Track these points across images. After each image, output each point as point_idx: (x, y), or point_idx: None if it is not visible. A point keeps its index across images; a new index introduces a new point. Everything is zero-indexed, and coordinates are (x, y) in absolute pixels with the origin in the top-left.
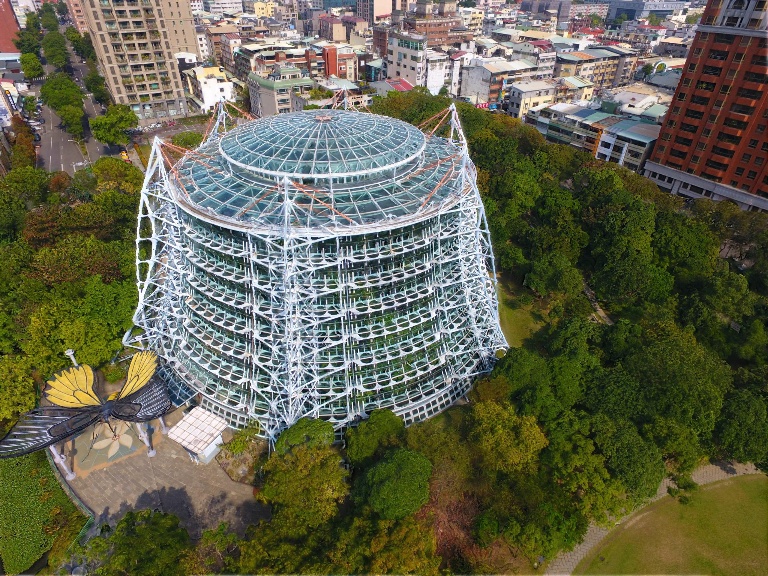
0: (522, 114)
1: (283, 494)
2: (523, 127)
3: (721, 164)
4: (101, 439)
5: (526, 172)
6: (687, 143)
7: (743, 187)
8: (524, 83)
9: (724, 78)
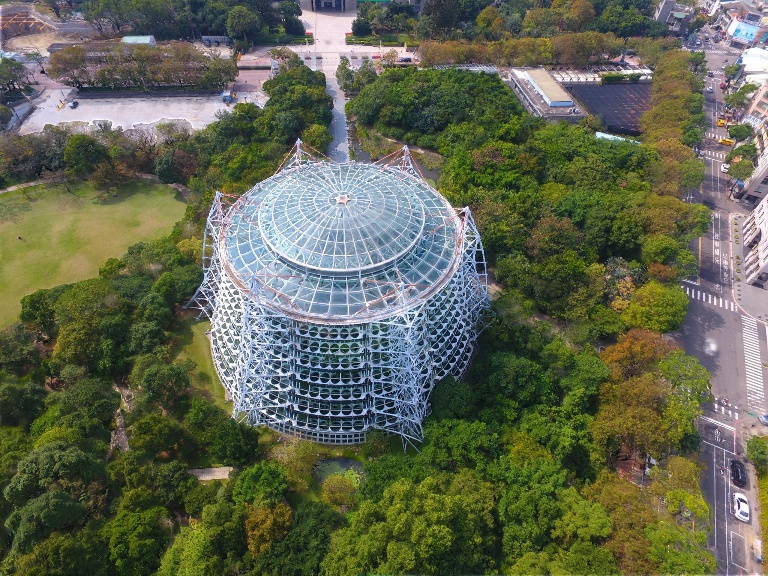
0: None
1: None
2: None
3: None
4: None
5: None
6: None
7: None
8: None
9: None
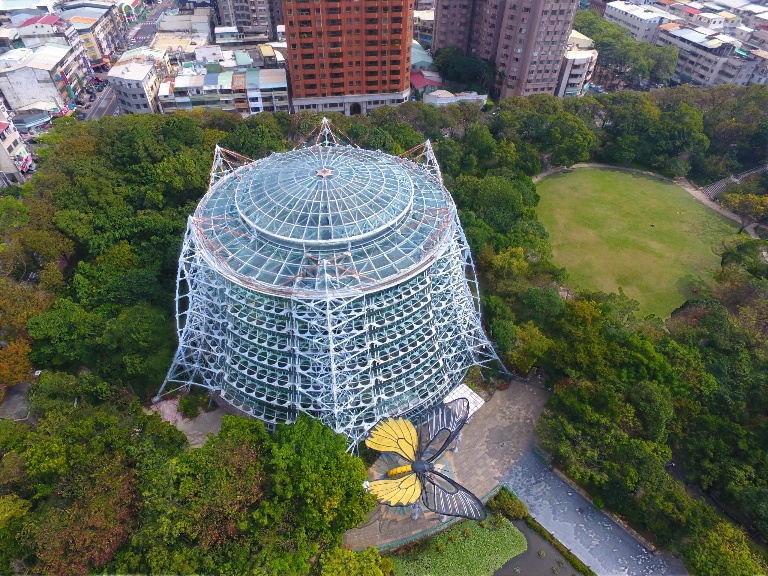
0: (150, 102)
1: (543, 347)
2: (215, 113)
3: (339, 83)
4: (430, 488)
5: (280, 146)
6: (312, 77)
7: (357, 92)
8: (126, 72)
9: (315, 27)
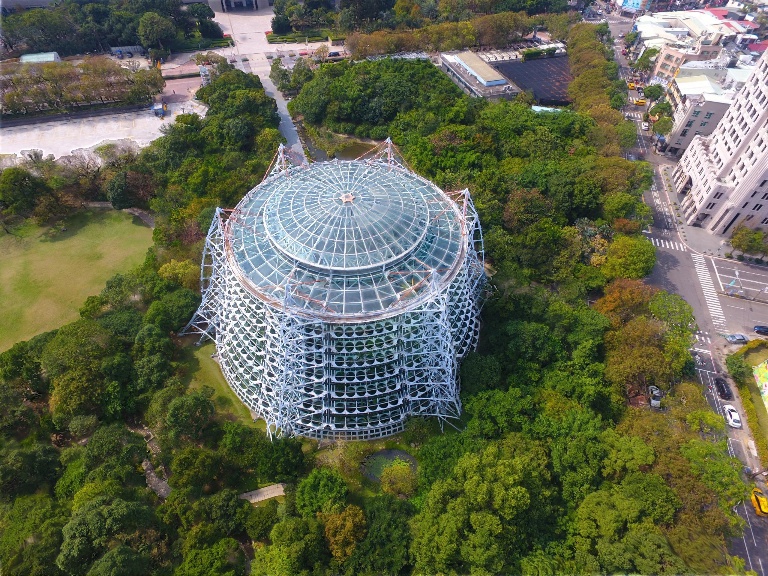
0: None
1: None
2: None
3: None
4: None
5: None
6: None
7: None
8: None
9: None
